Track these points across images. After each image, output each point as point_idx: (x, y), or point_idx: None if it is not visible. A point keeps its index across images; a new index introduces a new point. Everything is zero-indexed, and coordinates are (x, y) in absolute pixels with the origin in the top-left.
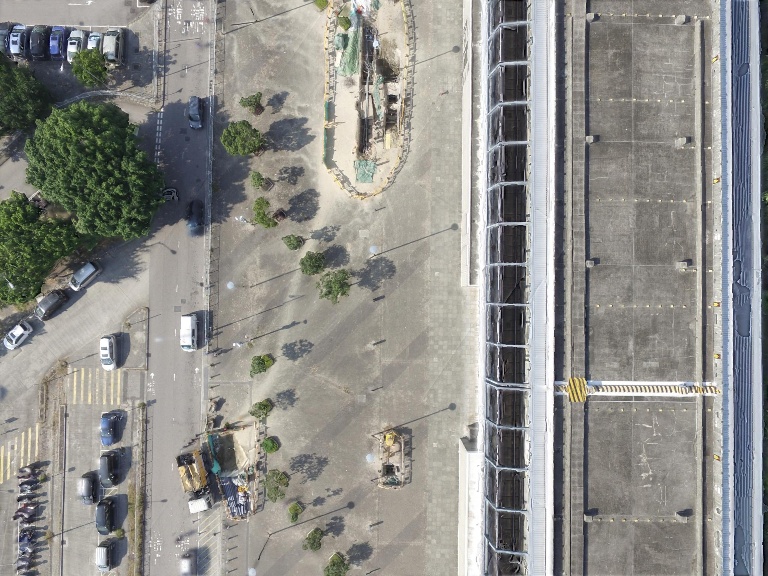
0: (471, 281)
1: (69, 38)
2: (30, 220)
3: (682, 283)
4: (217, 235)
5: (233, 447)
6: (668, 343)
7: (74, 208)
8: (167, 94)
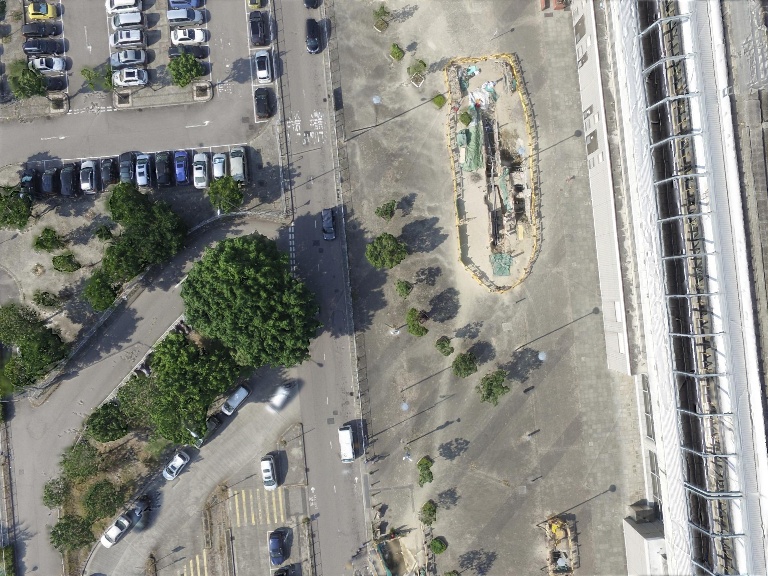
0: (632, 371)
1: (194, 163)
2: (192, 360)
3: None
4: (362, 344)
5: (401, 551)
6: None
7: (237, 345)
8: (295, 208)
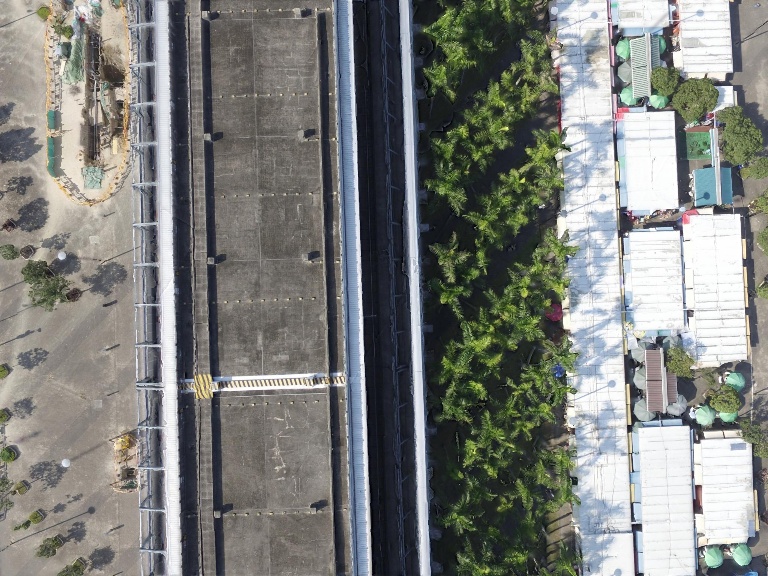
0: None
1: None
2: None
3: (310, 275)
4: None
5: None
6: (298, 336)
7: None
8: None
